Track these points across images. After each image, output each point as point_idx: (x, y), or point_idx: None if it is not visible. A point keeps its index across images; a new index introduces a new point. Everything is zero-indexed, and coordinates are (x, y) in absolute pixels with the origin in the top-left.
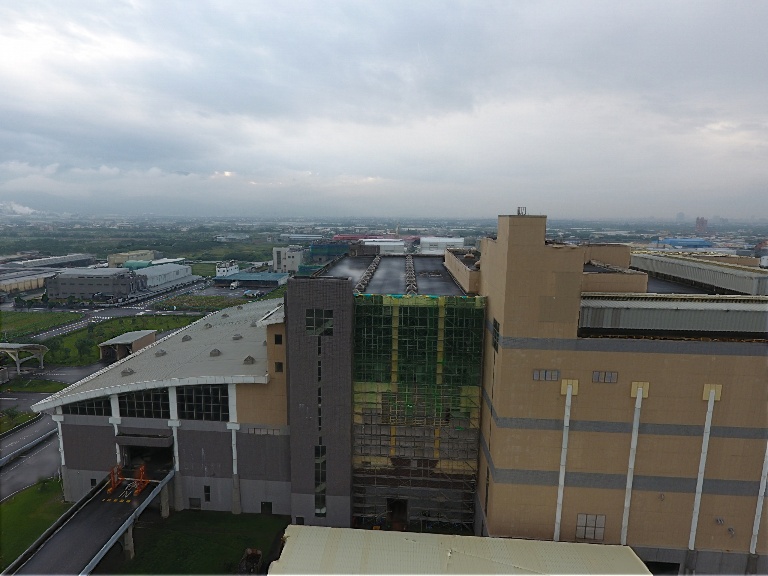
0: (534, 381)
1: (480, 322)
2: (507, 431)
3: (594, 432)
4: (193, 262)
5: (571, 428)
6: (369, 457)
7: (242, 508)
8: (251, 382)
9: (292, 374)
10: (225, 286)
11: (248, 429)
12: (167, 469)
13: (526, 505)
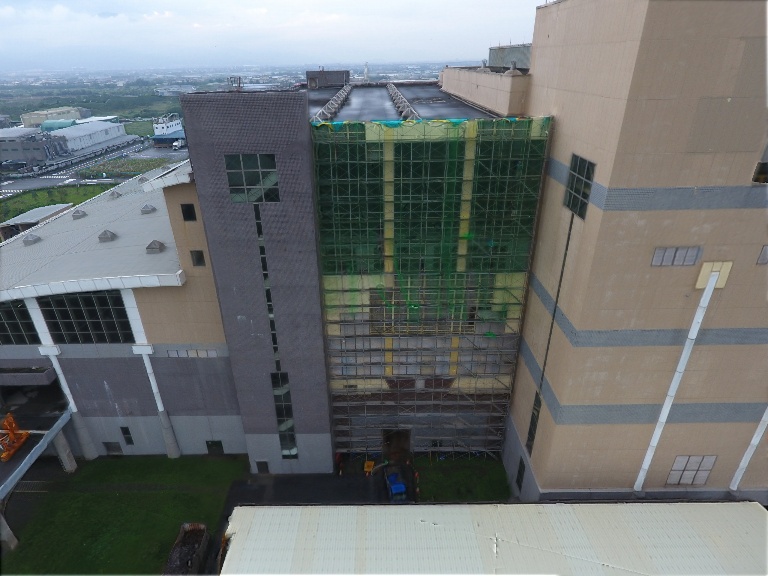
0: (652, 268)
1: (537, 165)
2: (589, 351)
3: (735, 345)
4: (129, 120)
5: (698, 341)
6: (354, 380)
7: (181, 450)
8: (155, 285)
9: (218, 270)
10: (167, 146)
11: (167, 352)
12: (59, 410)
13: (601, 450)
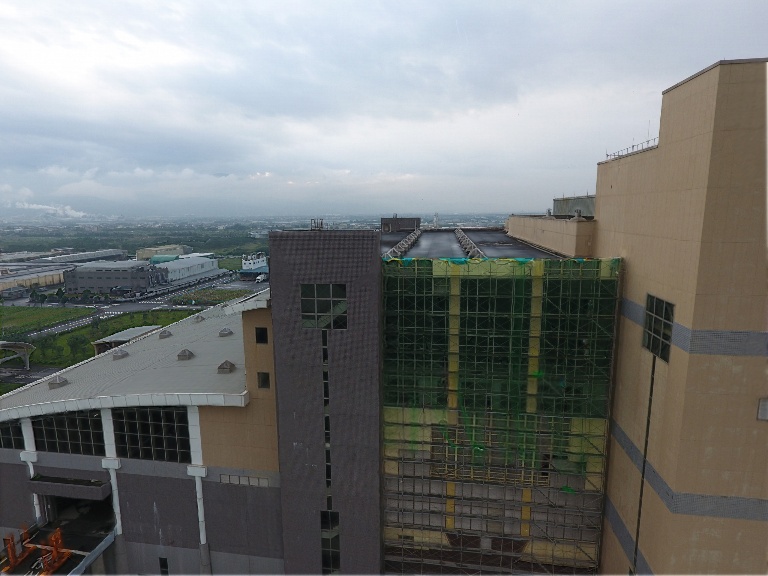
0: (758, 422)
1: (609, 304)
2: (692, 521)
3: None
4: (223, 257)
5: None
6: (411, 530)
7: None
8: (220, 404)
9: (281, 393)
10: (251, 279)
11: (220, 476)
12: (105, 530)
13: None
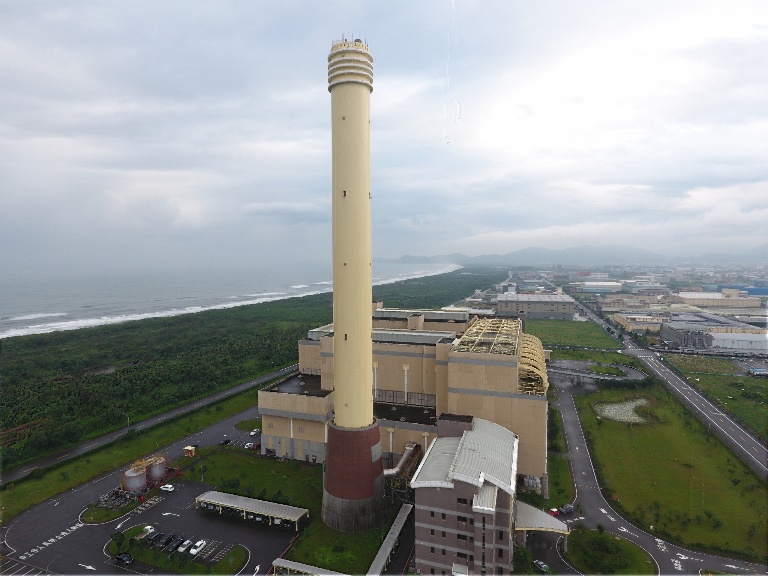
0: None
1: None
2: None
3: None
4: None
5: None
6: None
7: None
8: None
9: None
10: None
11: None
12: None
13: None
